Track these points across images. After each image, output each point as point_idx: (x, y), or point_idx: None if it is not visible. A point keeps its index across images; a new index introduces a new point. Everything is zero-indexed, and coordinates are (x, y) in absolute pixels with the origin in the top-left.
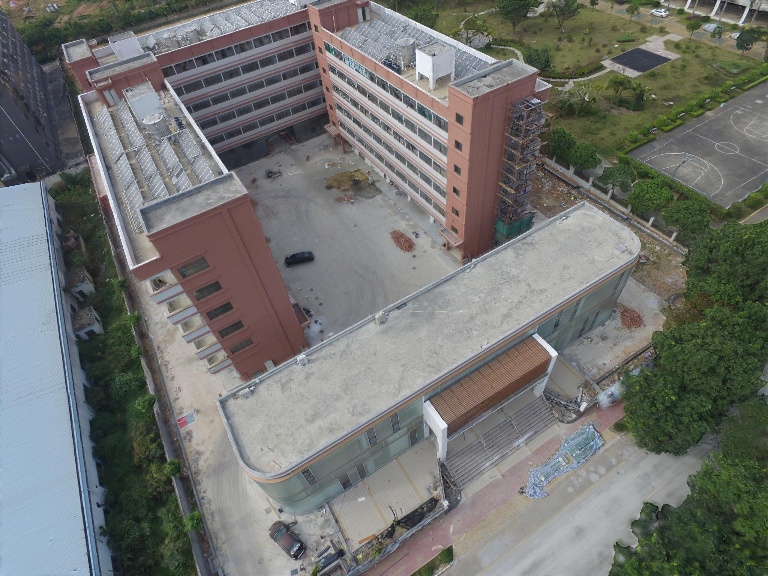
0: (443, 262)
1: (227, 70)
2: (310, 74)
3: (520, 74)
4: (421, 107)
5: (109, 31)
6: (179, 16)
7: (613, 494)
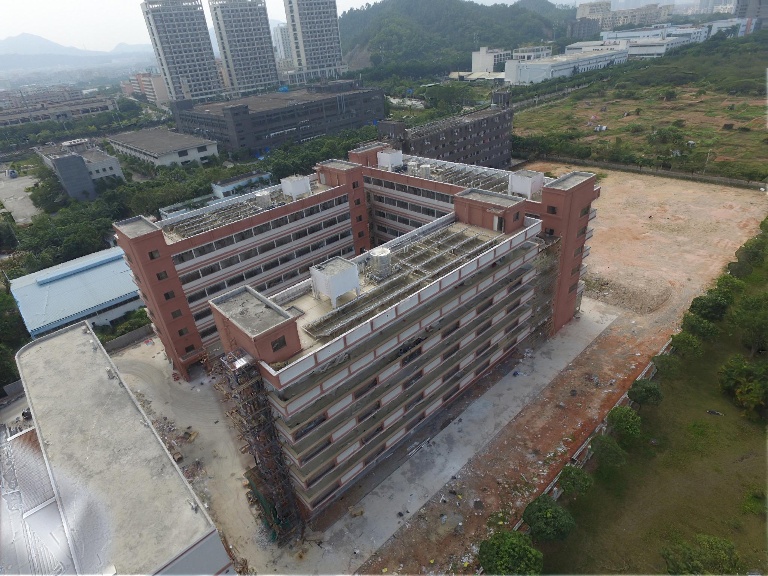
0: None
1: (427, 207)
2: None
3: (262, 329)
4: None
5: (584, 158)
6: (655, 171)
7: None
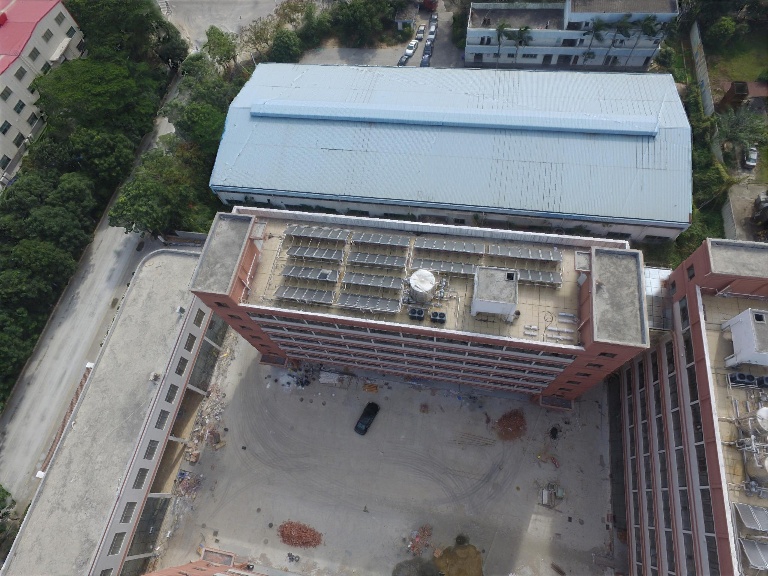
0: (238, 544)
1: None
2: None
3: None
4: None
5: None
6: None
7: (29, 456)
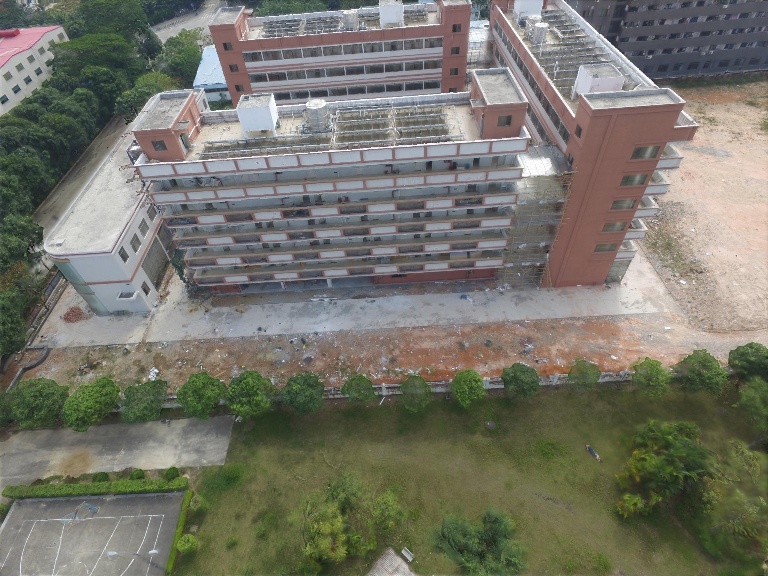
0: None
1: None
2: None
3: None
4: None
5: None
6: None
7: None
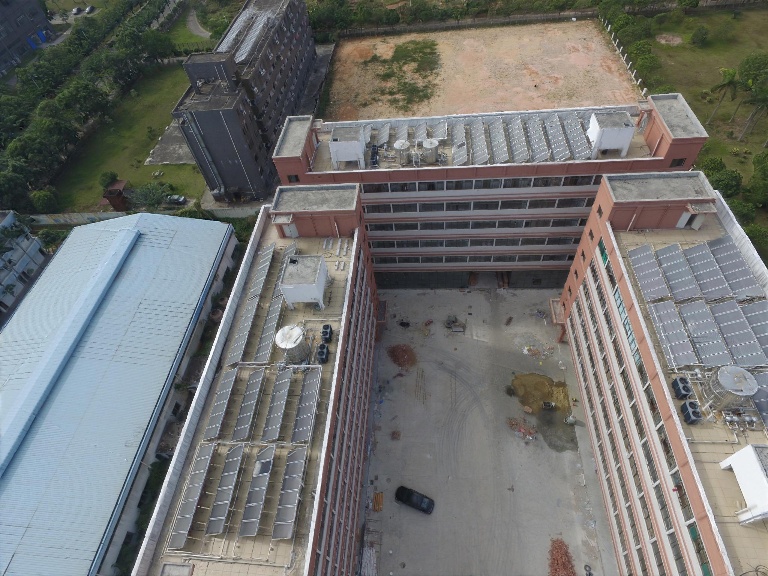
0: None
1: (454, 201)
2: (566, 229)
3: None
4: (698, 536)
5: (394, 24)
6: (473, 22)
7: None
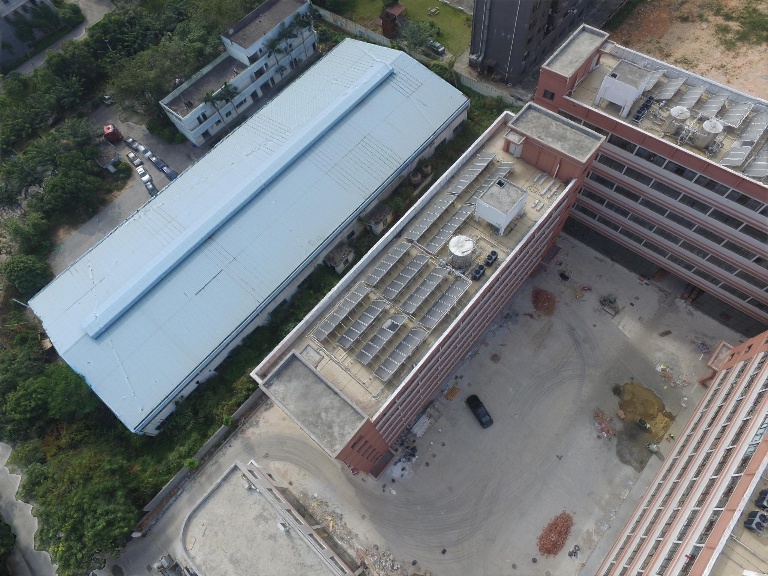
0: None
1: (694, 197)
2: None
3: None
4: None
5: None
6: None
7: None
